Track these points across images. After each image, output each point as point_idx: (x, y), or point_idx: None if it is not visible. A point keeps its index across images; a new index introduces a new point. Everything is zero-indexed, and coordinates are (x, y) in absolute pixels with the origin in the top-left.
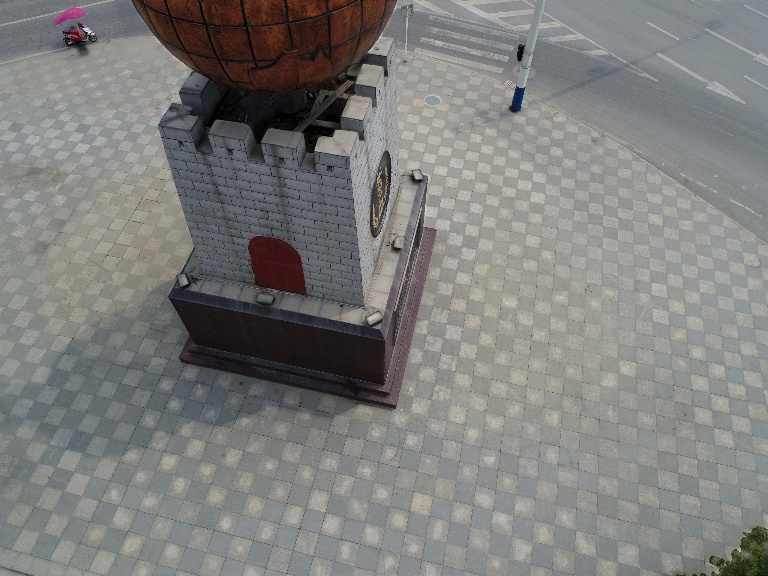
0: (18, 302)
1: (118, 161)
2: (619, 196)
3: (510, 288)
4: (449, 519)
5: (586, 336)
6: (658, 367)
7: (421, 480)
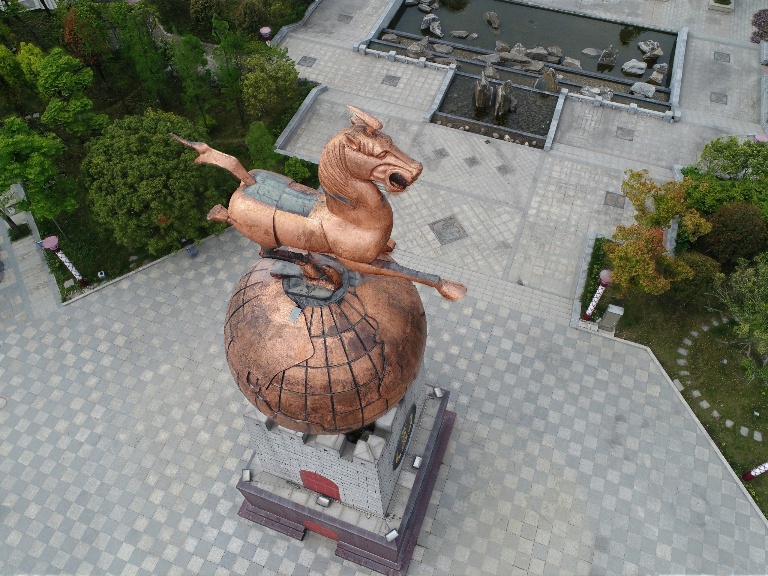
0: (597, 484)
1: None
2: (46, 545)
3: (198, 449)
4: None
5: (162, 402)
6: (126, 374)
7: None
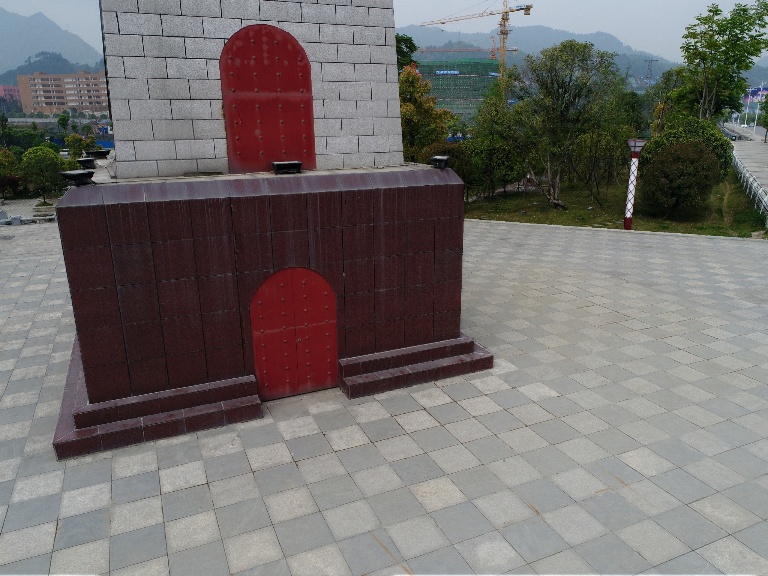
0: (549, 258)
1: (761, 329)
2: None
3: None
4: (3, 288)
5: None
6: None
7: (39, 293)
